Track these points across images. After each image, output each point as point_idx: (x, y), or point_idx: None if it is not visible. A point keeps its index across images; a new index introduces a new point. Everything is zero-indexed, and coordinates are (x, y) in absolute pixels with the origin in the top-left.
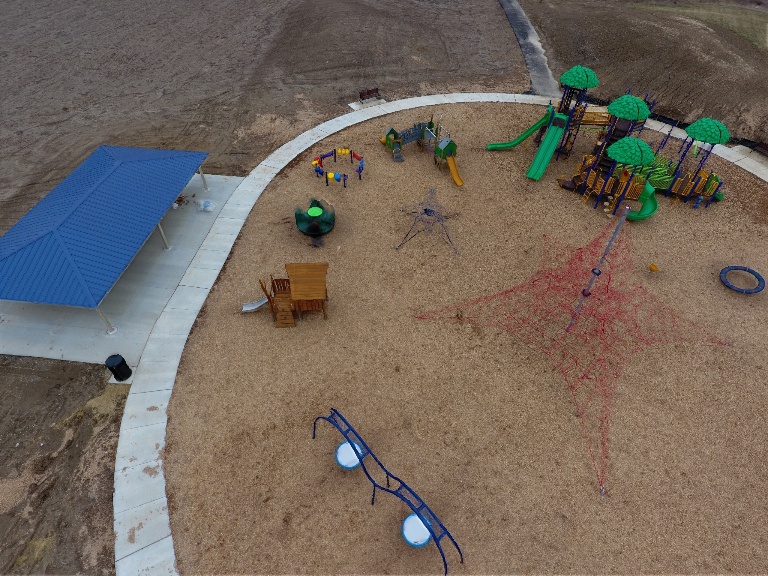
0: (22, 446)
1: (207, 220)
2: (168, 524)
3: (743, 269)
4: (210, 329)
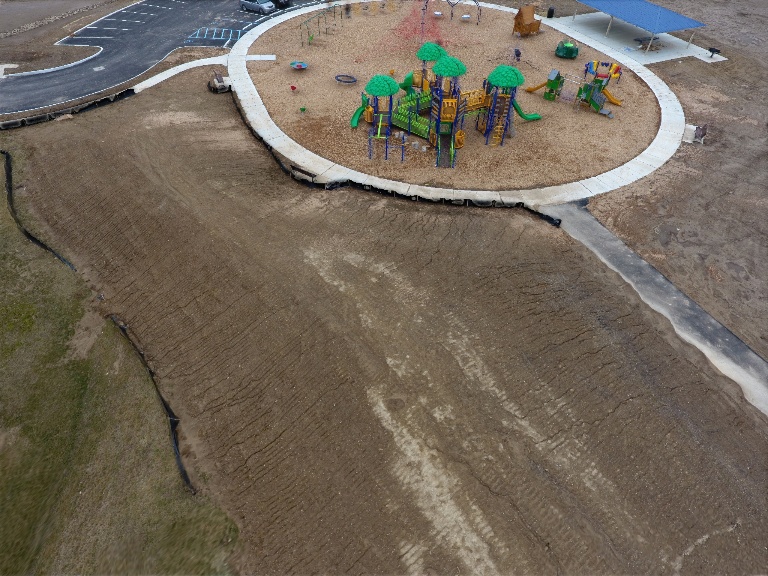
0: (547, 7)
1: (615, 47)
2: (494, 8)
3: (345, 81)
4: (545, 28)
